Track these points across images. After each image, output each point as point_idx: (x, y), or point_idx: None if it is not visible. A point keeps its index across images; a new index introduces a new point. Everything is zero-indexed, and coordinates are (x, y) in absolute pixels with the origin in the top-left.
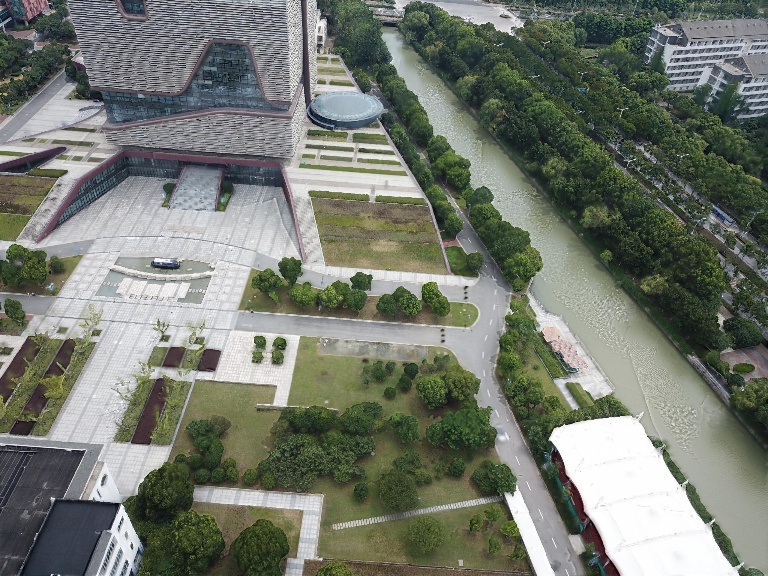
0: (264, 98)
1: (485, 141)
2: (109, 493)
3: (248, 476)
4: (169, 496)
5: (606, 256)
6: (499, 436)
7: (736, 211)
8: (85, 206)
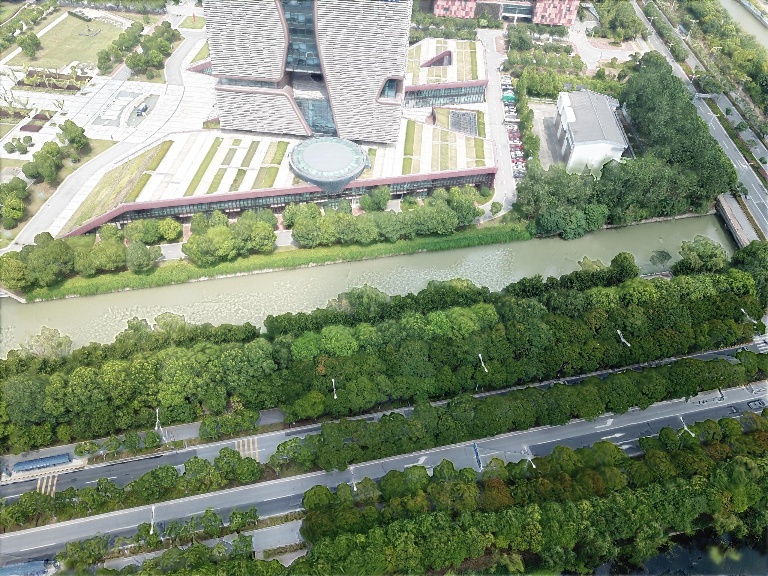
0: None
1: None
2: None
3: None
4: None
5: None
6: None
7: None
8: None
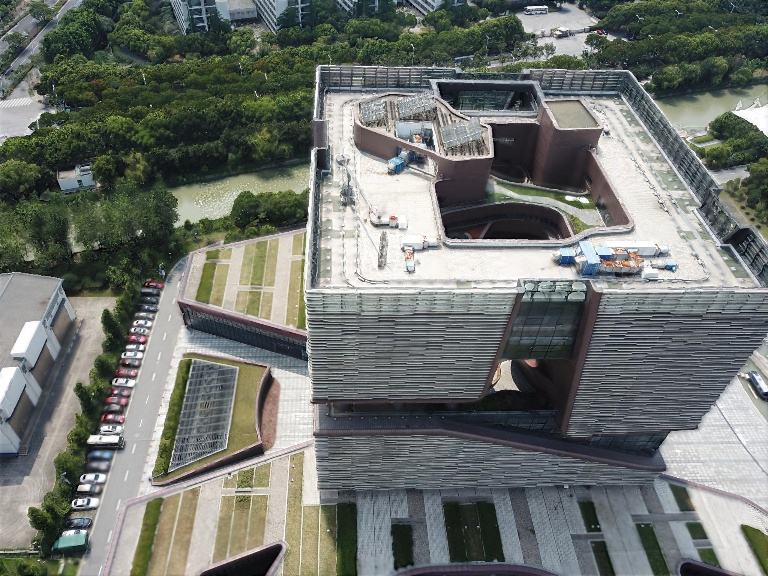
0: None
1: None
2: None
3: None
4: None
5: None
6: None
7: (464, 50)
8: None
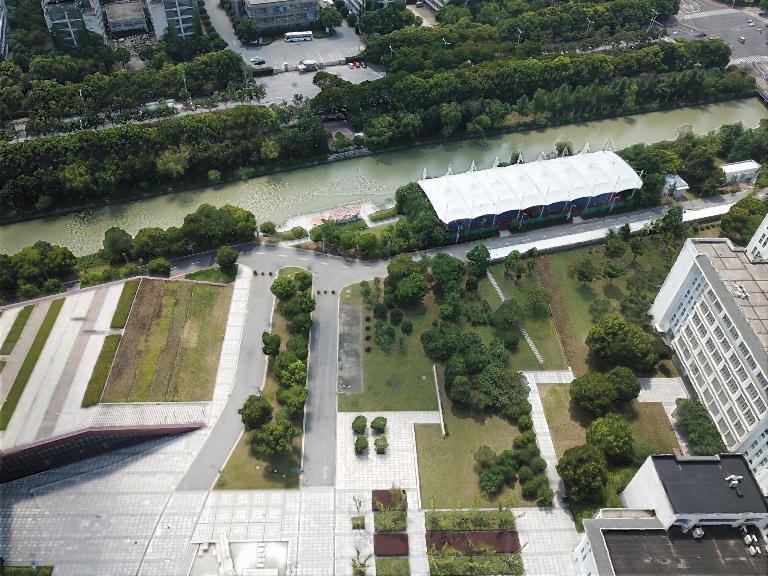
0: None
1: None
2: None
3: None
4: (599, 451)
5: (216, 175)
6: None
7: (162, 94)
8: None
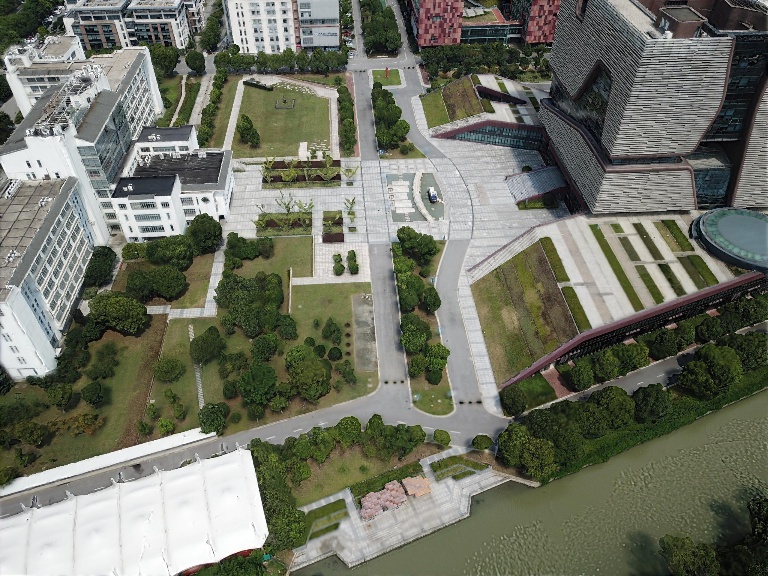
0: (601, 138)
1: None
2: (207, 211)
3: (224, 270)
4: None
5: None
6: (270, 431)
7: None
8: (484, 142)
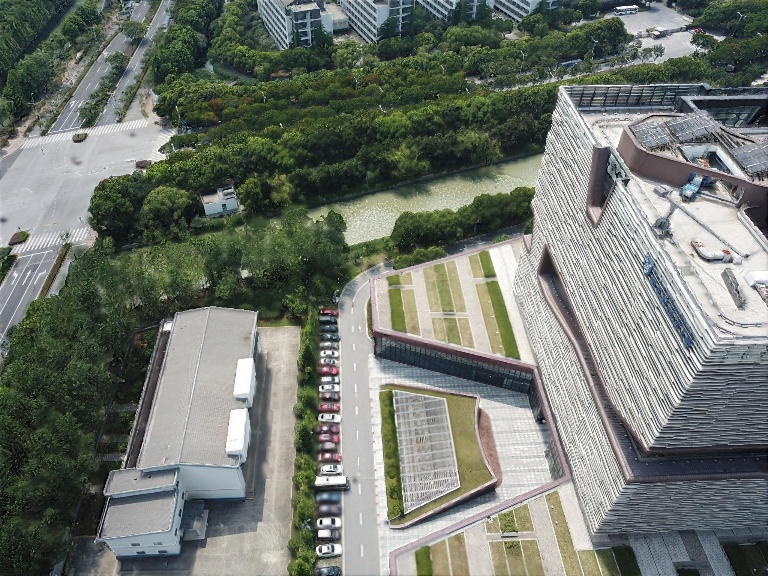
0: None
1: (496, 172)
2: None
3: None
4: None
5: None
6: None
7: None
8: None
